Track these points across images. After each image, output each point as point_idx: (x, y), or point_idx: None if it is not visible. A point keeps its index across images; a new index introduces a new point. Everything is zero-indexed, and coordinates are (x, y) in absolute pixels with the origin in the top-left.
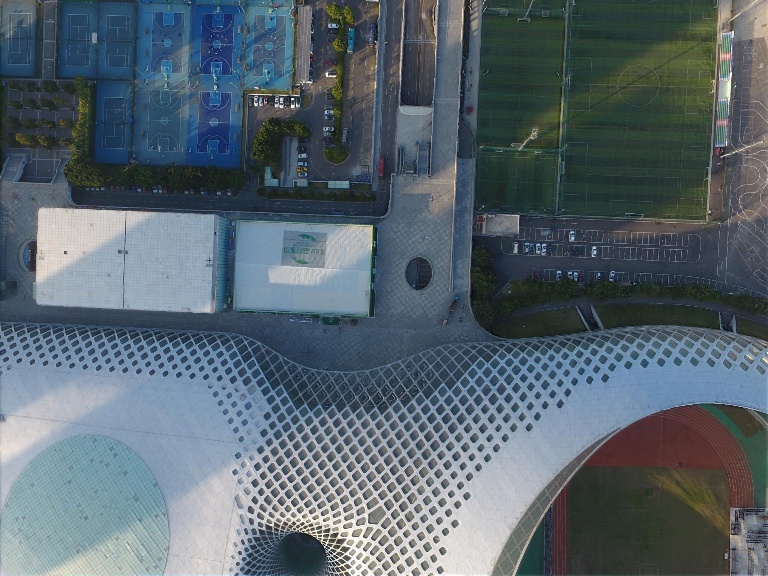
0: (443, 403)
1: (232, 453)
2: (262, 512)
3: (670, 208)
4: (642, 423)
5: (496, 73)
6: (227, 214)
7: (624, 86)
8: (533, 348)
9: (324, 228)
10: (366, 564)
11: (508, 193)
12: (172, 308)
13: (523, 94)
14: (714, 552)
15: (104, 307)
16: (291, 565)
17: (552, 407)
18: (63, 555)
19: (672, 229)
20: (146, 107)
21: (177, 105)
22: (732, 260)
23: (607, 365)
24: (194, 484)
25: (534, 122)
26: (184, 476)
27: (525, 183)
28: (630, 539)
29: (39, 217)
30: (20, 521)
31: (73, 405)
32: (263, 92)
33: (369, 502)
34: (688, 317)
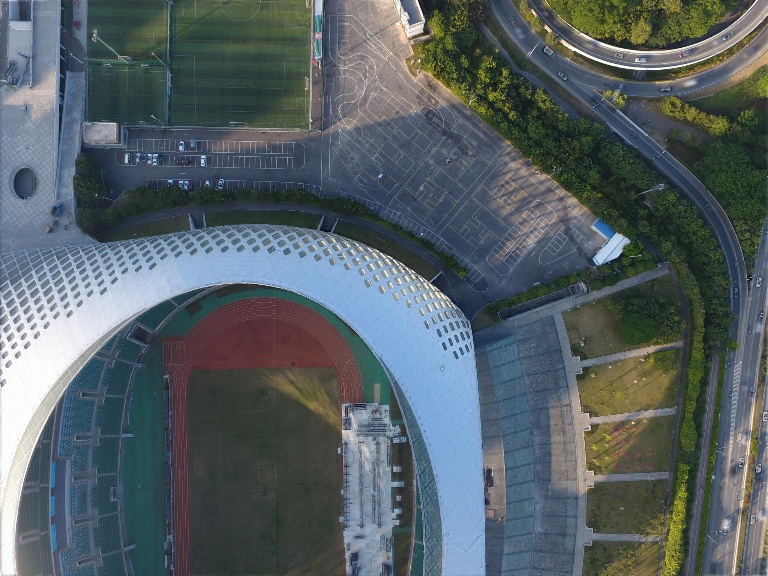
0: (1, 298)
1: None
2: None
3: (275, 118)
4: (256, 326)
5: None
6: None
7: (226, 1)
8: (108, 246)
9: None
10: None
11: (120, 106)
12: None
13: (130, 9)
14: (328, 448)
15: None
16: None
17: (95, 294)
18: None
19: (277, 138)
20: None
21: None
22: (334, 166)
23: (160, 255)
24: None
25: (143, 36)
26: None
27: (136, 96)
28: (248, 439)
29: None
30: None
31: None
32: None
33: None
34: (290, 220)
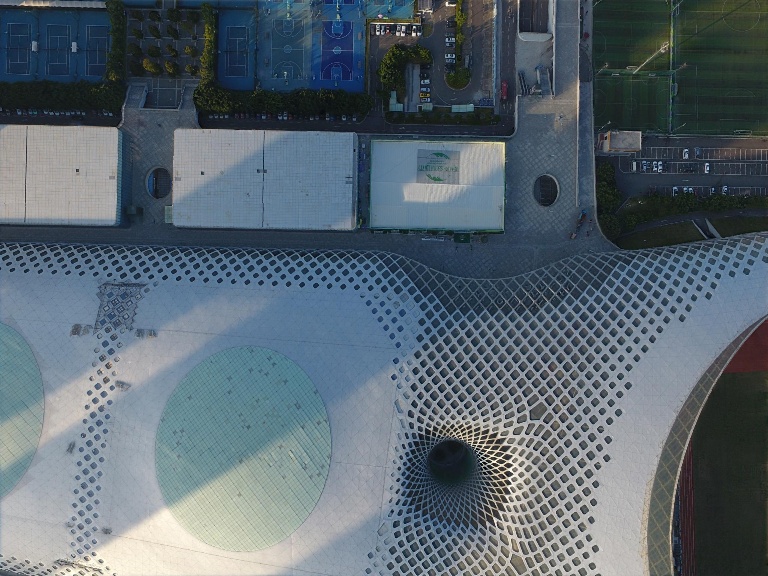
0: (593, 302)
1: (390, 359)
2: (422, 416)
3: None
4: (758, 330)
5: (609, 1)
6: None
7: (728, 13)
8: (668, 252)
9: (457, 146)
10: (530, 460)
11: (624, 114)
12: (312, 225)
13: (635, 21)
14: None
15: (243, 226)
16: (437, 477)
17: (701, 299)
18: (225, 466)
19: None
20: (269, 36)
21: (300, 34)
22: None
23: (746, 260)
24: (354, 390)
25: (646, 47)
26: (343, 383)
27: (640, 105)
28: (751, 442)
29: (175, 138)
30: (178, 435)
31: (226, 318)
32: (385, 21)
33: (529, 399)
34: None
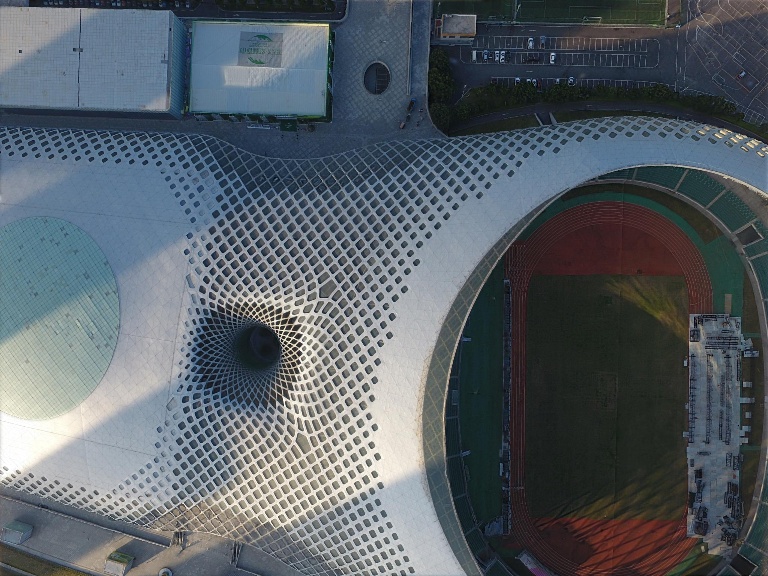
0: (395, 182)
1: (184, 233)
2: (214, 292)
3: (628, 13)
4: (601, 231)
5: None
6: (184, 21)
7: None
8: None
9: (280, 29)
10: (317, 338)
11: (467, 1)
12: (127, 106)
13: None
14: (673, 359)
15: (59, 106)
16: (247, 364)
17: (503, 177)
18: (13, 332)
19: (630, 34)
20: None
21: None
22: (690, 64)
23: (559, 140)
24: (145, 264)
25: None
26: (135, 256)
27: None
28: (589, 348)
29: None
30: None
31: (25, 190)
32: None
33: (320, 277)
34: None
